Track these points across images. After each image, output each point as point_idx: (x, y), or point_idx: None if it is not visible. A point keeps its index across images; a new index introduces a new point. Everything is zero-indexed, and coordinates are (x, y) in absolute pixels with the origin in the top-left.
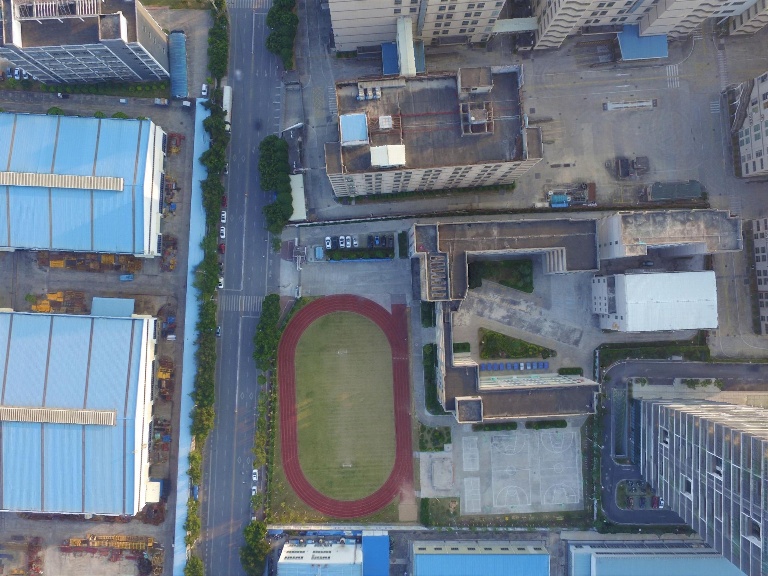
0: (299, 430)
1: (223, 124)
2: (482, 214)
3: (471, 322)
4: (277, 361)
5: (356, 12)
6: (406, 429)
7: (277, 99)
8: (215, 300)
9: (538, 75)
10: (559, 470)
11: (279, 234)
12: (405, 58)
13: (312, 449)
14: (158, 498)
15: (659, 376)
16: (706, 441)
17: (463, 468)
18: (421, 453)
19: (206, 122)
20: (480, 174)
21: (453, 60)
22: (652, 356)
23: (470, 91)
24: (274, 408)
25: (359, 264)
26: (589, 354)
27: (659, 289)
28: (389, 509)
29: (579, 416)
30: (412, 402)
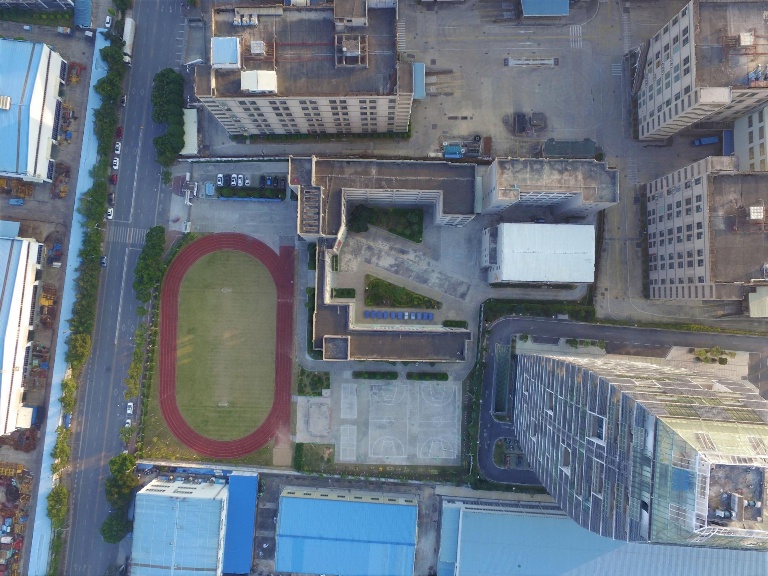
0: (178, 366)
1: (119, 53)
2: None
3: (358, 268)
4: (161, 295)
5: None
6: (286, 372)
7: (180, 35)
8: (103, 230)
9: (441, 27)
10: (438, 423)
11: (169, 167)
12: None
13: (190, 386)
14: (29, 424)
15: (544, 335)
16: (546, 378)
17: (340, 415)
18: (299, 397)
19: (102, 50)
20: (363, 113)
21: None
22: (537, 313)
23: (343, 22)
24: (154, 342)
25: (250, 203)
26: (475, 308)
27: (536, 239)
28: (263, 452)
29: (461, 370)
30: (294, 345)
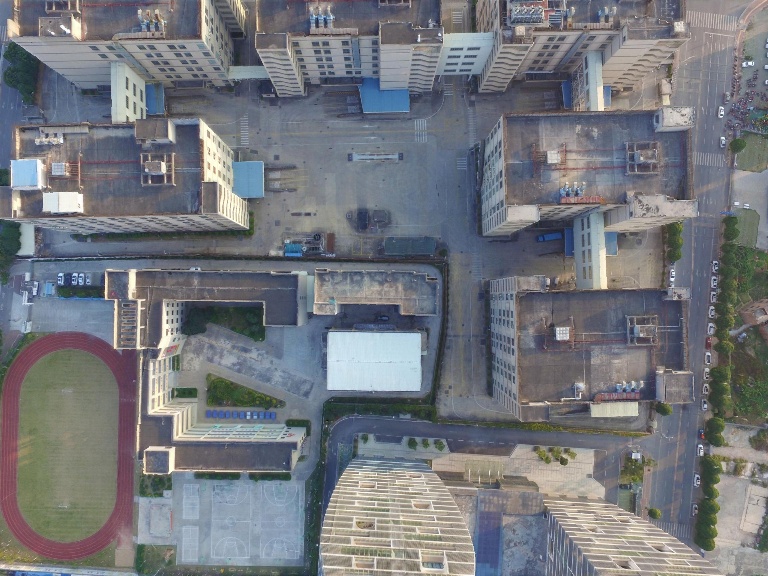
0: (19, 467)
1: None
2: (218, 259)
3: (200, 367)
4: (2, 395)
5: (59, 55)
6: (128, 472)
7: None
8: None
9: (284, 122)
10: (280, 524)
11: (6, 268)
12: (115, 102)
13: (31, 487)
14: None
15: (388, 433)
16: None
17: (182, 516)
18: (141, 498)
19: None
20: (186, 222)
21: (200, 103)
22: None
23: (145, 142)
24: None
25: (92, 302)
26: (319, 407)
27: (362, 348)
28: (105, 553)
29: (305, 469)
30: None
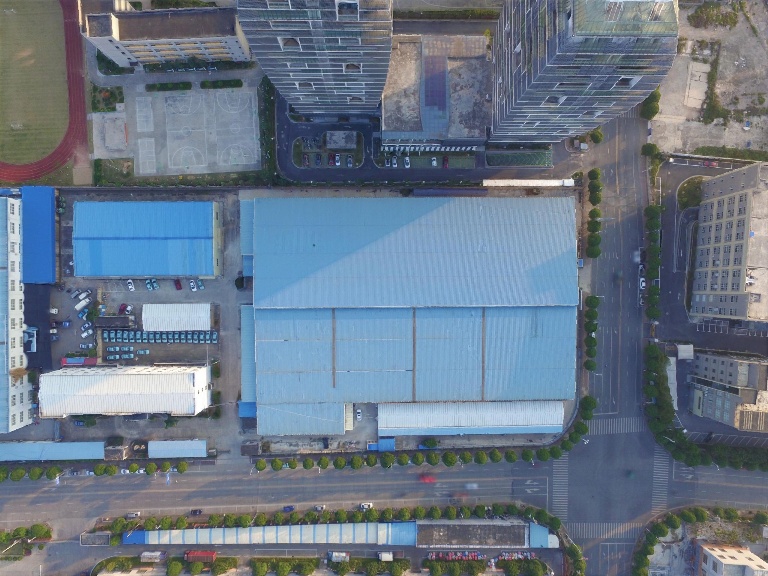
0: None
1: None
2: None
3: None
4: None
5: None
6: (79, 91)
7: None
8: None
9: None
10: (236, 130)
11: None
12: None
13: None
14: None
15: None
16: None
17: (137, 129)
18: (94, 114)
19: None
20: None
21: None
22: None
23: None
24: None
25: None
26: None
27: None
28: (62, 172)
29: (255, 76)
30: (85, 64)
